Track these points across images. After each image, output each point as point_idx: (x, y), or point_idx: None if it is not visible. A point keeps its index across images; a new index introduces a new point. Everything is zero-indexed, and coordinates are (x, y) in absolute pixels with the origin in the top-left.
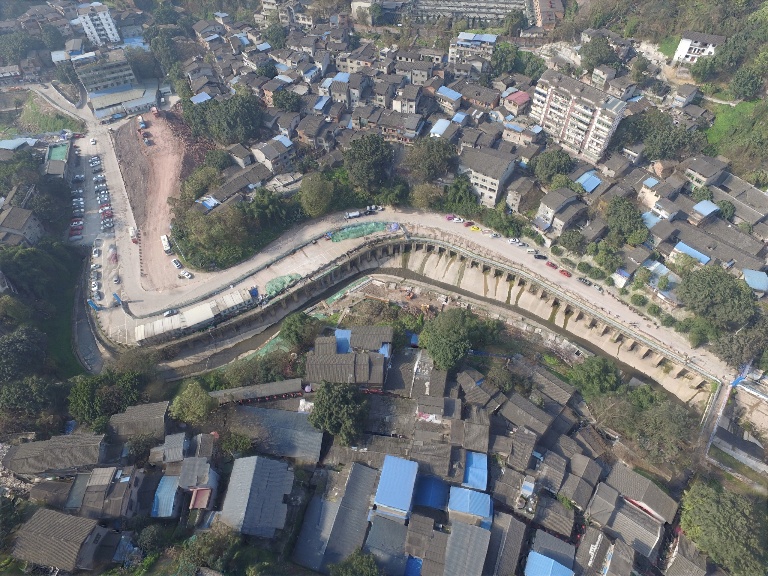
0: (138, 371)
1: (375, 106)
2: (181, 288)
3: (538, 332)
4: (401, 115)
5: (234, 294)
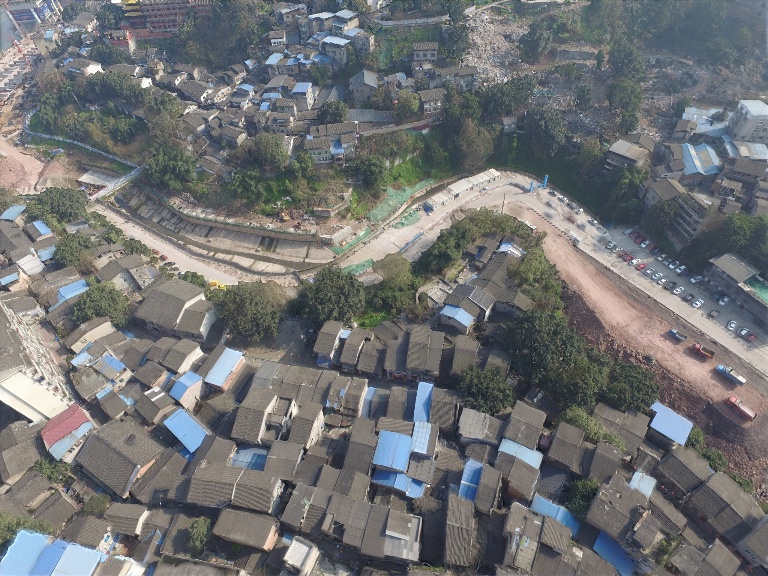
0: (452, 112)
1: (328, 406)
2: (490, 206)
3: (203, 215)
4: (283, 386)
5: (441, 200)
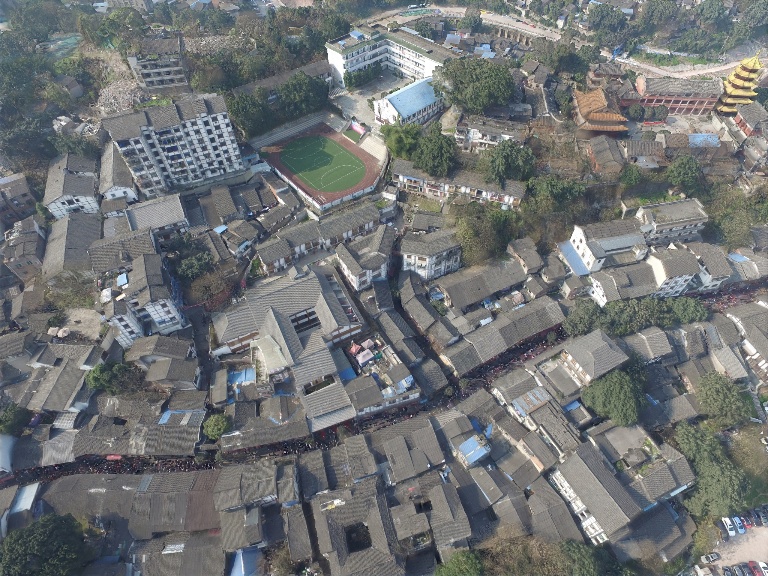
0: None
1: None
2: None
3: None
4: None
5: None
